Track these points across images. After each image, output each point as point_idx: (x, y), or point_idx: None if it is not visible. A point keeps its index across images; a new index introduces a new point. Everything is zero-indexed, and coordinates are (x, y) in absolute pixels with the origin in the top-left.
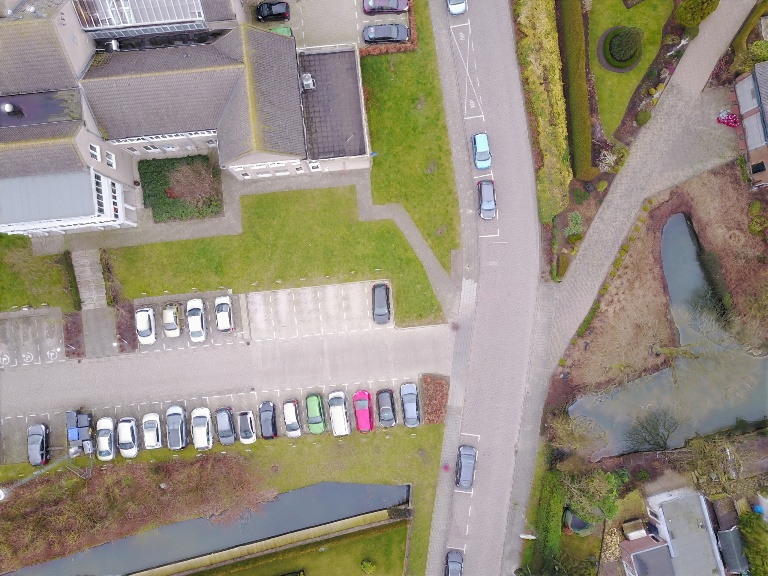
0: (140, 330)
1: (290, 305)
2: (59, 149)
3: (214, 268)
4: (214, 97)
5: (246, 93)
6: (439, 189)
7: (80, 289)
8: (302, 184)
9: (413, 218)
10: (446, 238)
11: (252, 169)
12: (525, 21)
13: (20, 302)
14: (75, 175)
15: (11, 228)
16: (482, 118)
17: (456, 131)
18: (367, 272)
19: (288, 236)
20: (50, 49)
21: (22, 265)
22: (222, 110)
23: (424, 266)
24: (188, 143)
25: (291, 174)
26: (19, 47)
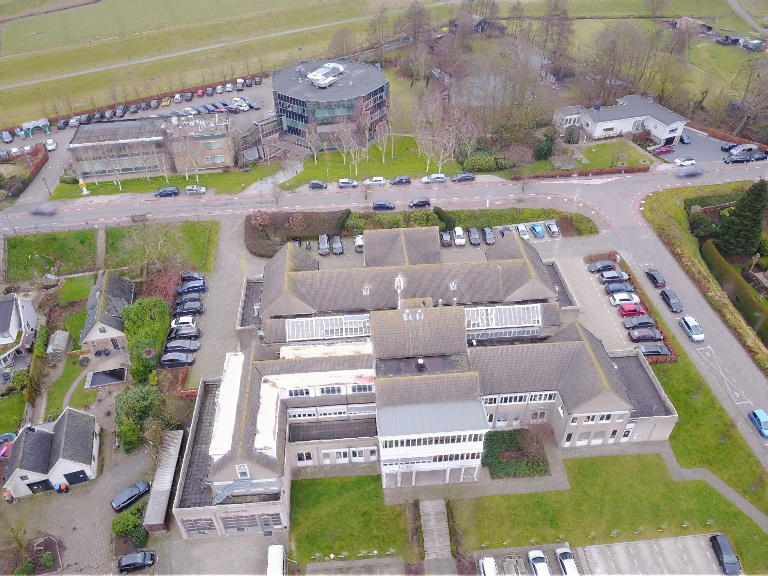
0: (489, 575)
1: (630, 559)
2: (465, 380)
3: (549, 521)
4: (560, 364)
5: (589, 356)
6: (738, 454)
7: (424, 538)
8: (614, 451)
9: (723, 479)
10: (763, 493)
11: (584, 424)
12: (752, 345)
13: (366, 550)
14: (469, 403)
15: (401, 453)
16: (750, 403)
17: (733, 412)
18: (698, 526)
19: (613, 492)
20: (456, 325)
21: (373, 513)
22: (564, 374)
23: (753, 519)
24: (519, 415)
25: (603, 443)
26: (437, 323)
